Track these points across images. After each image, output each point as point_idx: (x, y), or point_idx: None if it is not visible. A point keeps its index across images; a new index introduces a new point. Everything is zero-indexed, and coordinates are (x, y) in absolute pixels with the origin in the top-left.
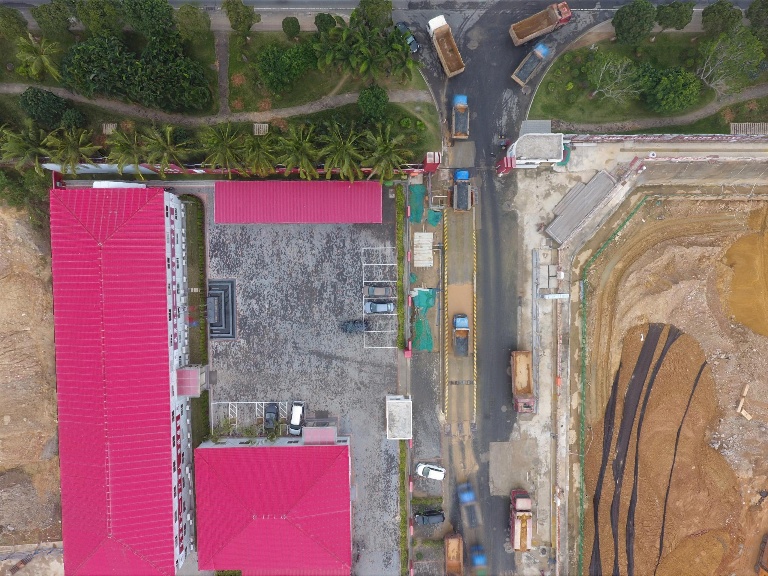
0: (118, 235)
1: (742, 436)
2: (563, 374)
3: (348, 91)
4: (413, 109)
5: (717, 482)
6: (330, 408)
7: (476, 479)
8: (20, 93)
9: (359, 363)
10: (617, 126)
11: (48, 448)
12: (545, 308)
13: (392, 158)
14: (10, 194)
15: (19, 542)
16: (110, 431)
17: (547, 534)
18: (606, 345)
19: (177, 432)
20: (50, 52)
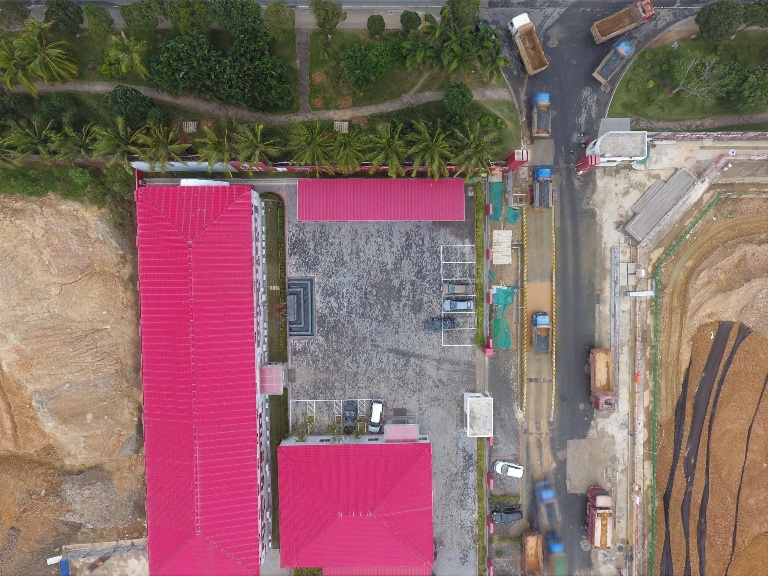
0: (207, 233)
1: None
2: (641, 372)
3: (428, 89)
4: (493, 107)
5: None
6: (408, 406)
7: (553, 477)
8: (101, 91)
9: (437, 361)
10: (696, 124)
11: (128, 446)
12: (623, 306)
13: (484, 156)
14: (92, 192)
15: (97, 540)
16: (199, 429)
17: (624, 532)
18: (677, 343)
19: (260, 430)
20: (140, 50)
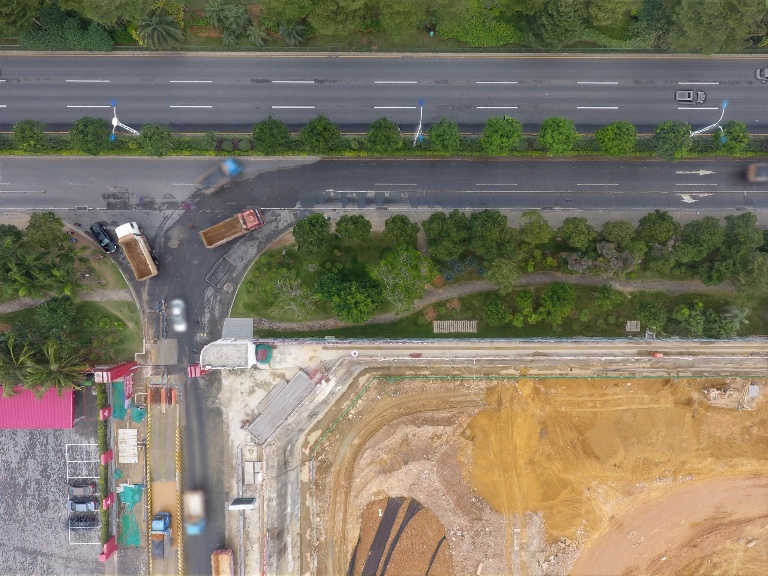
0: None
1: None
2: (272, 569)
3: None
4: (113, 308)
5: None
6: None
7: None
8: None
9: (65, 559)
10: (319, 324)
11: None
12: None
13: None
14: None
15: None
16: None
17: None
18: (341, 522)
19: None
20: None
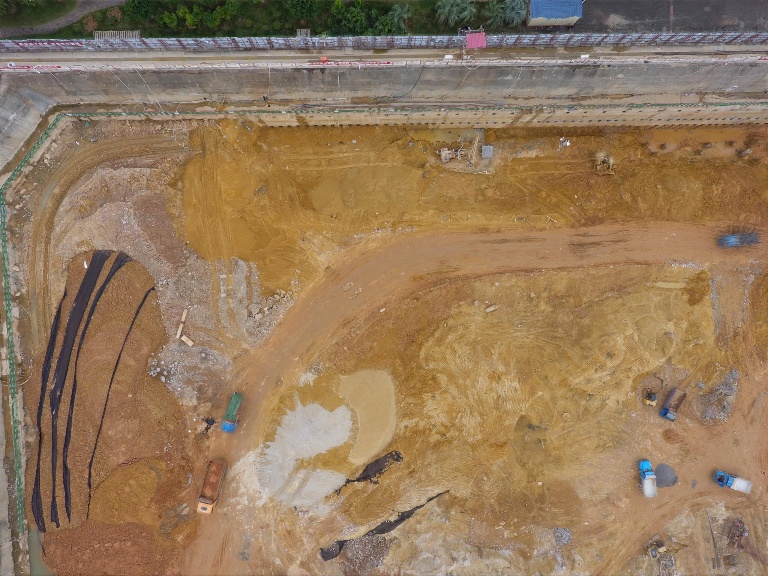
0: None
1: (183, 363)
2: None
3: None
4: None
5: (152, 410)
6: None
7: None
8: None
9: None
10: None
11: None
12: None
13: None
14: None
15: None
16: None
17: None
18: (43, 273)
19: None
20: None
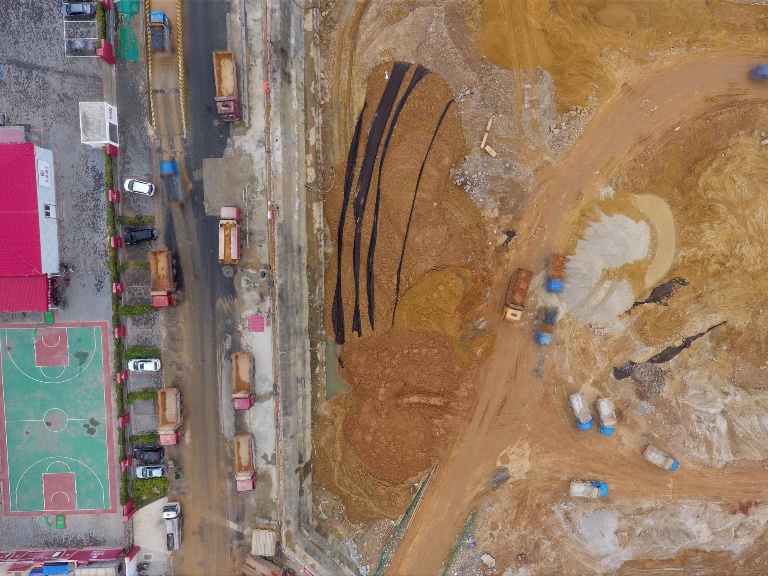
0: None
1: (486, 173)
2: (276, 85)
3: None
4: None
5: (458, 217)
6: (32, 121)
7: (190, 198)
8: None
9: (61, 73)
10: None
11: None
12: (254, 14)
13: None
14: None
15: None
16: None
17: (266, 256)
18: (347, 81)
19: None
20: None
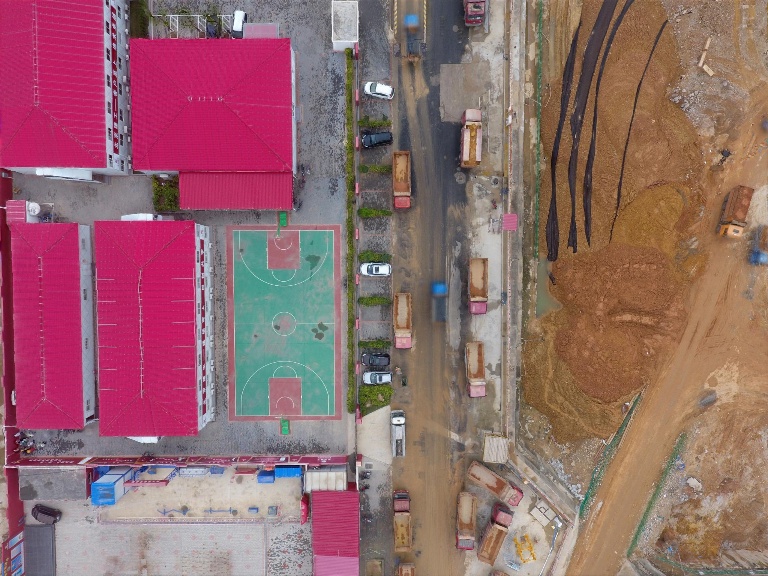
0: None
1: (704, 91)
2: None
3: None
4: None
5: (677, 134)
6: None
7: (426, 103)
8: None
9: None
10: None
11: None
12: None
13: None
14: None
15: None
16: None
17: (499, 163)
18: None
19: (112, 23)
20: None
